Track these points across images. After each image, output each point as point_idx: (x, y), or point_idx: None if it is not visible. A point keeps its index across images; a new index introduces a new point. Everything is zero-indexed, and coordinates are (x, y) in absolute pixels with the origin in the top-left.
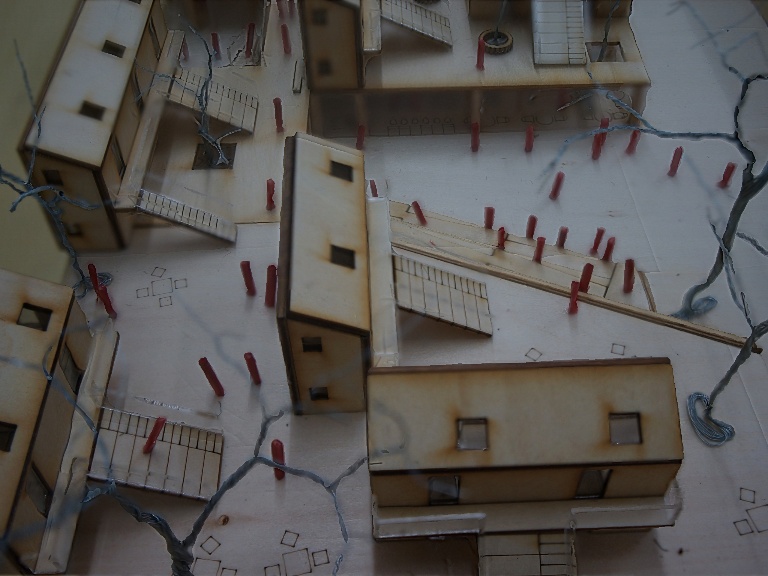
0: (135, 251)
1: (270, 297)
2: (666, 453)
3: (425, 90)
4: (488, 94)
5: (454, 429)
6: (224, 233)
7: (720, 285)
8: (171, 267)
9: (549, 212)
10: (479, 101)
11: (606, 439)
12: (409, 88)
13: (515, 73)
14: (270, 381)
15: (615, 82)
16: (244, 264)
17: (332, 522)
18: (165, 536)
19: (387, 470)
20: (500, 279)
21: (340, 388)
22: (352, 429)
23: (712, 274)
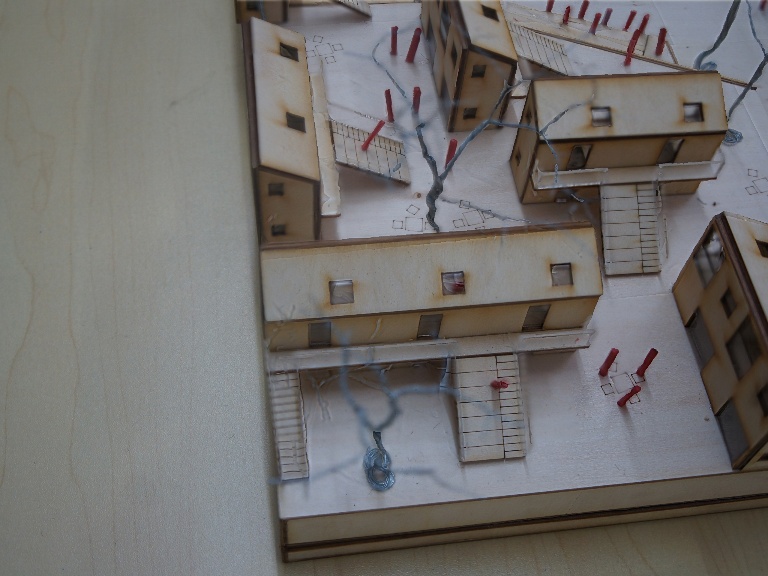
0: (295, 24)
1: (411, 55)
2: (718, 127)
3: None
4: None
5: (590, 114)
6: (364, 9)
7: (718, 54)
8: (326, 35)
9: None
10: None
11: (682, 119)
12: None
13: None
14: (425, 111)
15: None
16: (394, 29)
17: (490, 194)
18: (434, 170)
19: (550, 139)
20: (573, 43)
21: (485, 109)
22: (490, 140)
23: (718, 40)
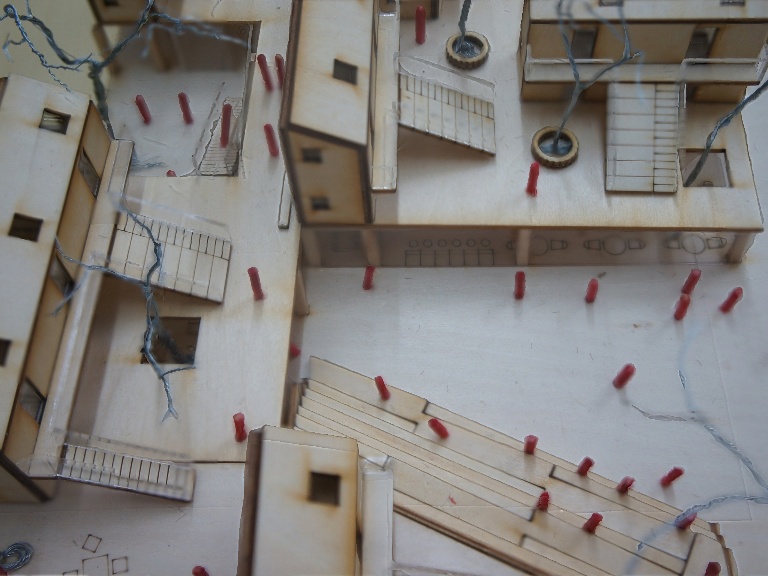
0: (63, 506)
1: None
2: None
3: (455, 228)
4: (540, 231)
5: None
6: (177, 491)
7: None
8: (108, 535)
9: (611, 409)
10: (527, 238)
11: None
12: (434, 225)
13: (578, 204)
14: None
15: (714, 226)
16: (197, 572)
17: None
18: None
19: None
20: None
21: None
22: None
23: None
